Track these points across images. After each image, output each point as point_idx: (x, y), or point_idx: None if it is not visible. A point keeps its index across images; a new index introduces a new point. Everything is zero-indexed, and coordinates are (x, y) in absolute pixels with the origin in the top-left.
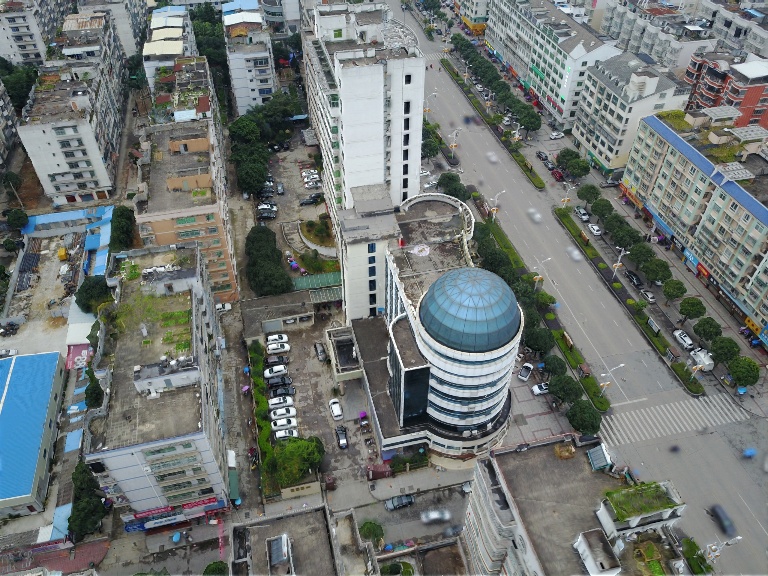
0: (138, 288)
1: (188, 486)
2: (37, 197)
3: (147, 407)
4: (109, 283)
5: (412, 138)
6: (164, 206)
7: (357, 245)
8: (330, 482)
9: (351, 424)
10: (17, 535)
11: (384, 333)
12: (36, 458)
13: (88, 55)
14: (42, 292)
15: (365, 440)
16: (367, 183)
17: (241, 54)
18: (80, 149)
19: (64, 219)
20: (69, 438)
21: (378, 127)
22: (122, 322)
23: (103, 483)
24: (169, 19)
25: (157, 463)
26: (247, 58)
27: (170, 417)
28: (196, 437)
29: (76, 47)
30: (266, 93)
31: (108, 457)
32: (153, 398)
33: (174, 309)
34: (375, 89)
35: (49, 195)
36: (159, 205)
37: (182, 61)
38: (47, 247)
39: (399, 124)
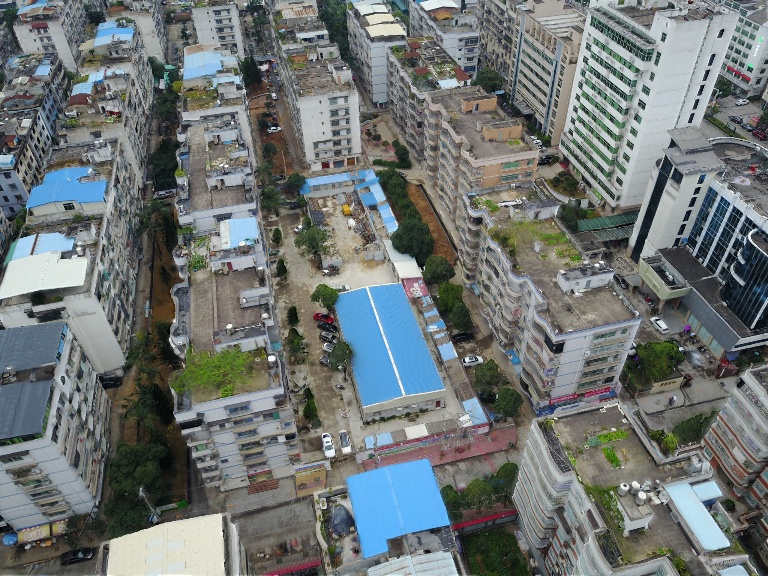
0: (514, 215)
1: (601, 373)
2: (297, 164)
3: (578, 303)
4: (475, 214)
5: (706, 88)
6: (490, 153)
7: (694, 176)
8: (690, 378)
9: (677, 337)
10: (442, 422)
11: (692, 259)
12: (433, 363)
13: (318, 38)
14: (342, 241)
15: (699, 348)
16: (660, 130)
17: (455, 34)
18: (345, 118)
19: (332, 181)
20: (442, 350)
21: (687, 77)
22: (515, 241)
23: (551, 365)
24: (374, 6)
25: (598, 347)
26: (460, 38)
27: (603, 309)
28: (635, 323)
29: (307, 32)
30: (470, 70)
31: (569, 339)
32: (579, 296)
33: (547, 232)
34: (696, 42)
35: (309, 162)
36: (485, 153)
37: (413, 40)
38: (325, 205)
39: (700, 75)
